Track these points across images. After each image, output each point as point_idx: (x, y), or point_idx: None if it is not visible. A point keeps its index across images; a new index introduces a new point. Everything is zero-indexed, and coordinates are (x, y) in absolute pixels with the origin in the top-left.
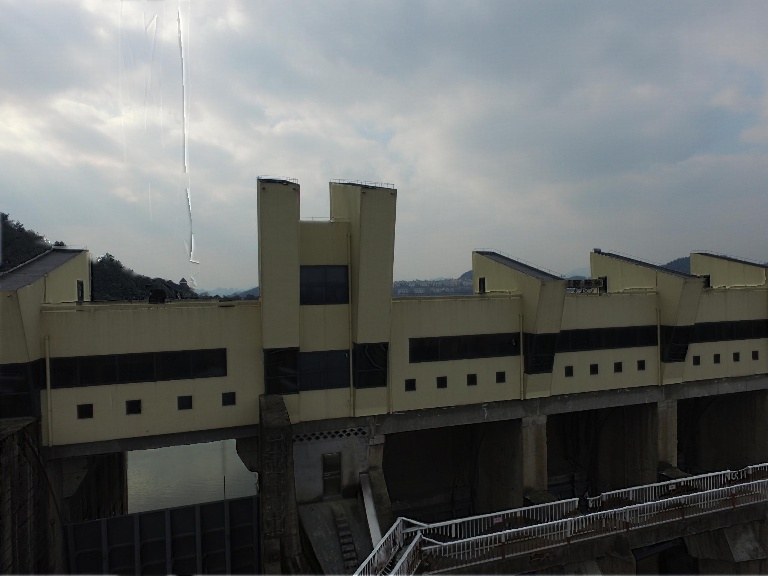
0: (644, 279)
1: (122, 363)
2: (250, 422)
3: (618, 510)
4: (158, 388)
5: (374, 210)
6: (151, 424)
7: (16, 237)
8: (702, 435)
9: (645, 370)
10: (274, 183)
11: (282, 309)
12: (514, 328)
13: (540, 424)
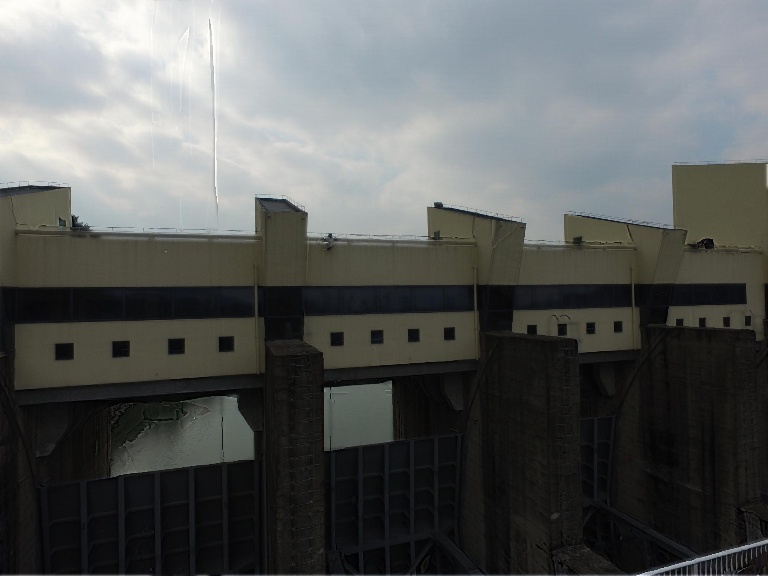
0: None
1: (695, 290)
2: (759, 339)
3: None
4: (714, 310)
5: None
6: None
7: None
8: None
9: None
10: None
11: None
12: None
13: None
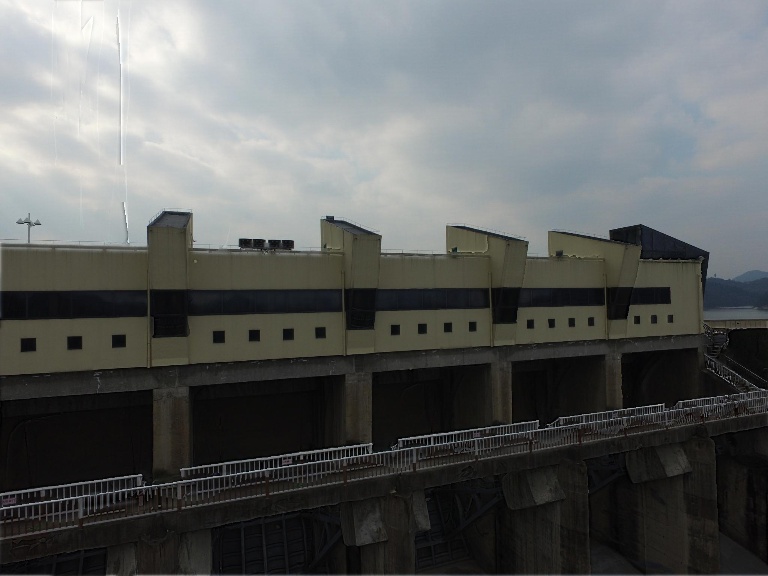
0: (338, 240)
1: None
2: None
3: (164, 485)
4: None
5: None
6: None
7: None
8: (455, 418)
9: (326, 338)
10: None
11: None
12: (140, 285)
13: (179, 397)
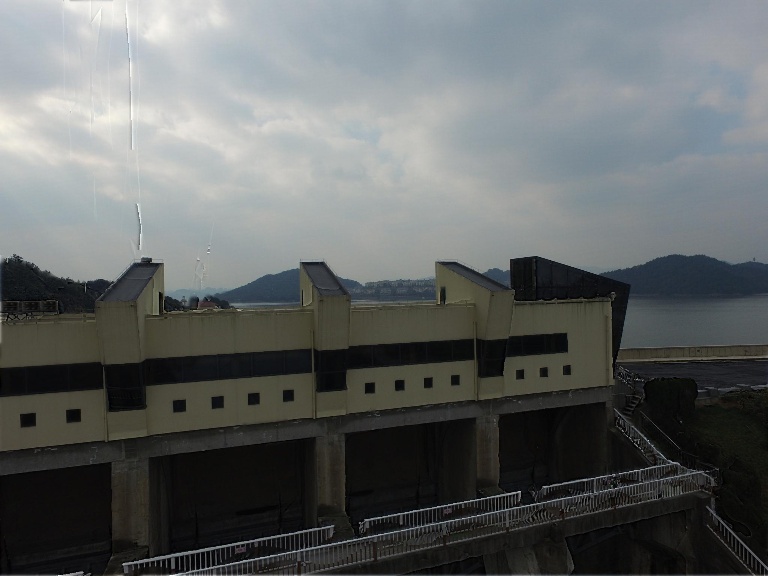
0: None
1: None
2: None
3: None
4: None
5: None
6: None
7: None
8: (305, 486)
9: (81, 422)
10: None
11: None
12: None
13: None
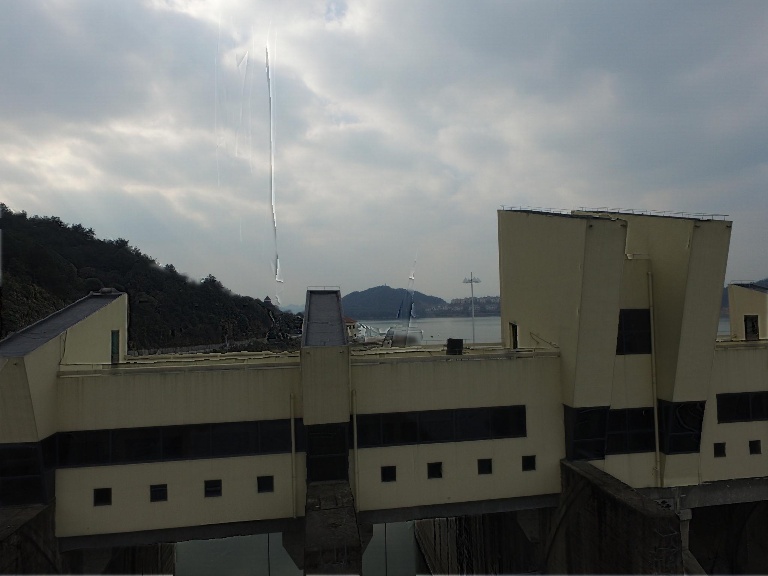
0: None
1: (422, 421)
2: (551, 490)
3: None
4: (458, 449)
5: (705, 246)
6: (452, 490)
7: (136, 261)
8: None
9: None
10: (601, 219)
11: (596, 362)
12: None
13: None
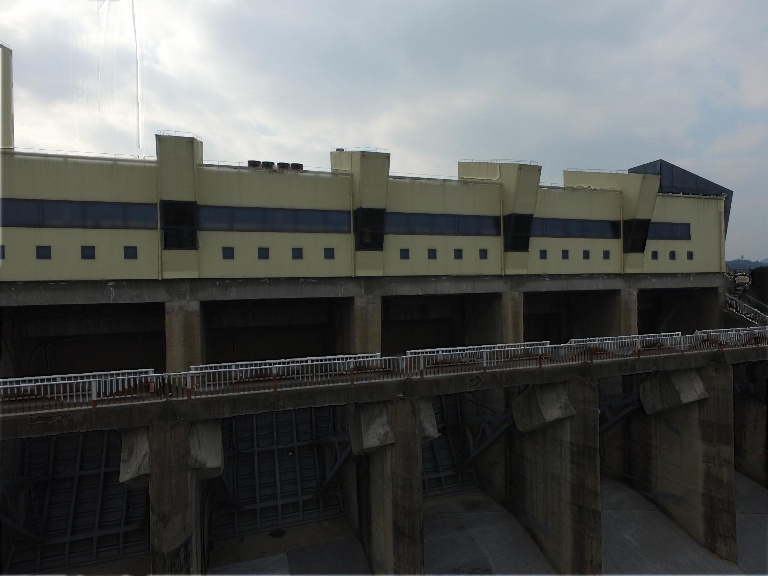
0: (346, 164)
1: None
2: None
3: (174, 374)
4: None
5: None
6: None
7: None
8: None
9: (335, 259)
10: None
11: None
12: (150, 198)
13: (190, 310)
